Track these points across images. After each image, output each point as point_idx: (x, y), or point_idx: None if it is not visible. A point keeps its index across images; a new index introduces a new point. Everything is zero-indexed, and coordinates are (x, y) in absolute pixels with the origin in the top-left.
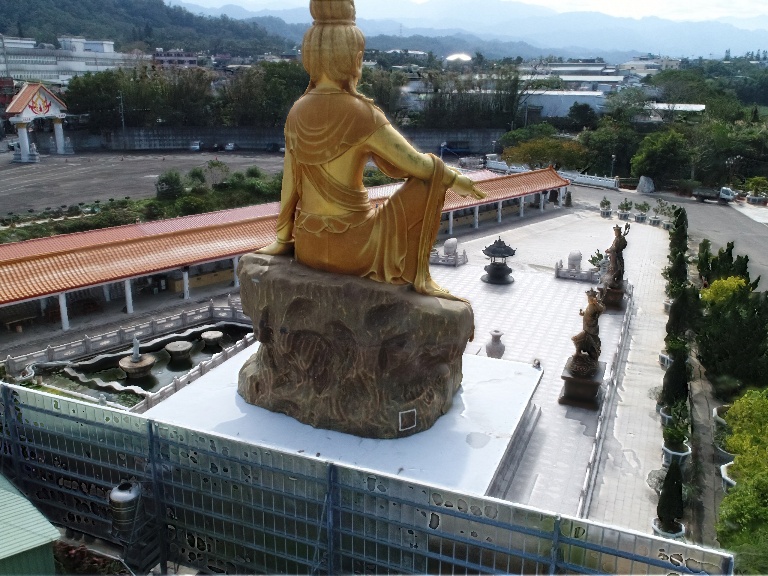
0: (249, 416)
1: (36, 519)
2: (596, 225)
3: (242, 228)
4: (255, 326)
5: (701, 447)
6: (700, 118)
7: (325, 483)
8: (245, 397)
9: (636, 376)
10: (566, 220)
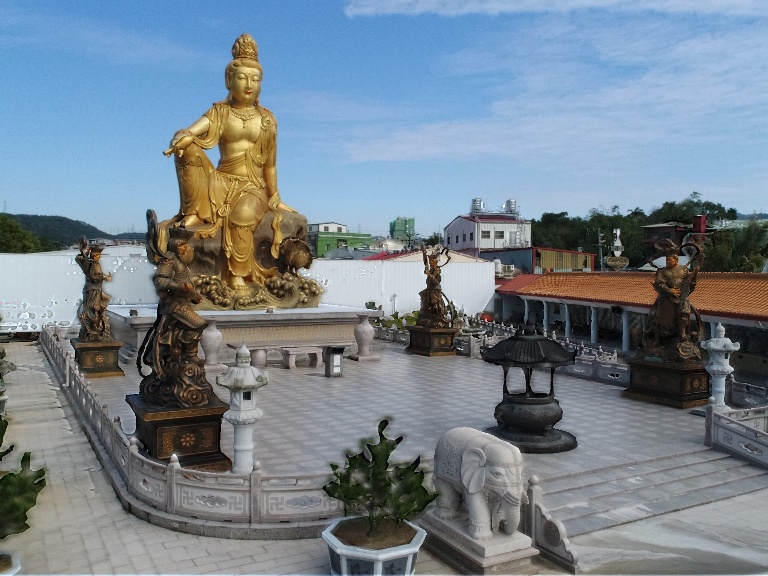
0: None
1: None
2: None
3: None
4: None
5: None
6: None
7: (141, 266)
8: None
9: (40, 399)
10: None
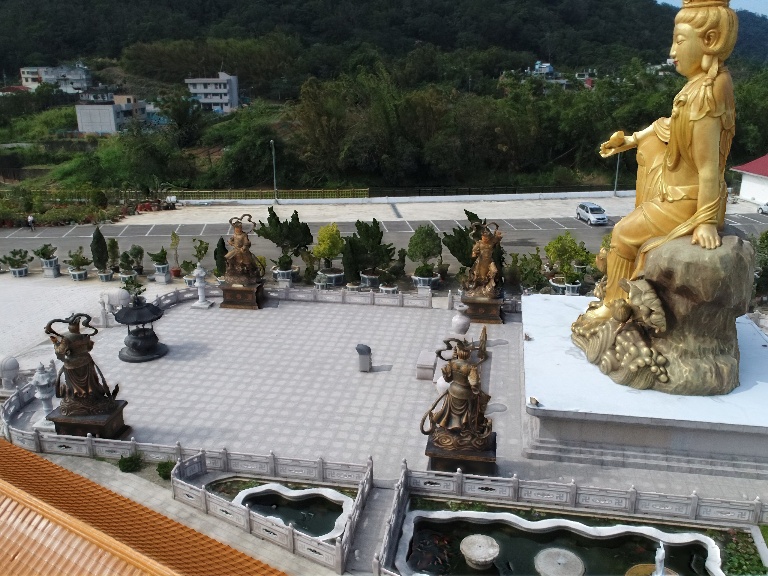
0: (759, 380)
1: None
2: None
3: (52, 504)
4: None
5: (519, 297)
6: None
7: None
8: None
9: None
10: None
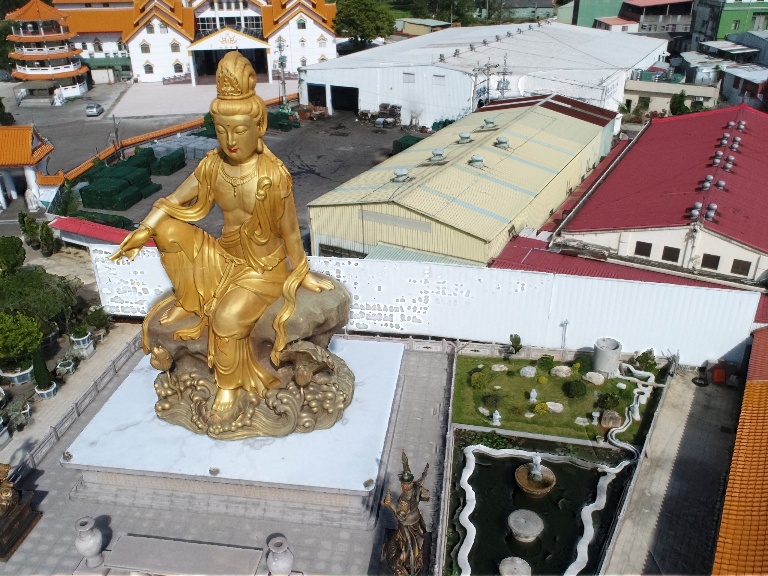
0: None
1: None
2: None
3: None
4: None
5: None
6: None
7: None
8: None
9: None
10: None
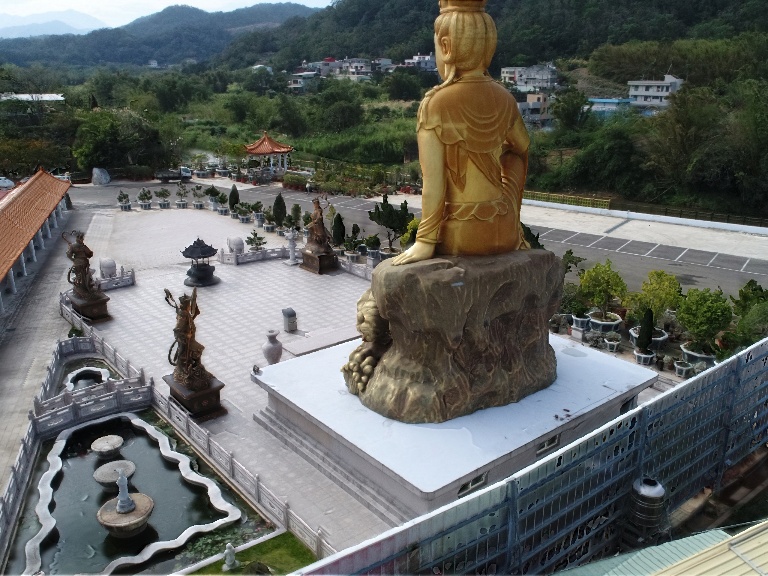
0: (470, 427)
1: (691, 542)
2: (141, 219)
3: None
4: (456, 333)
5: None
6: (64, 107)
7: None
8: (431, 420)
9: None
10: (104, 221)
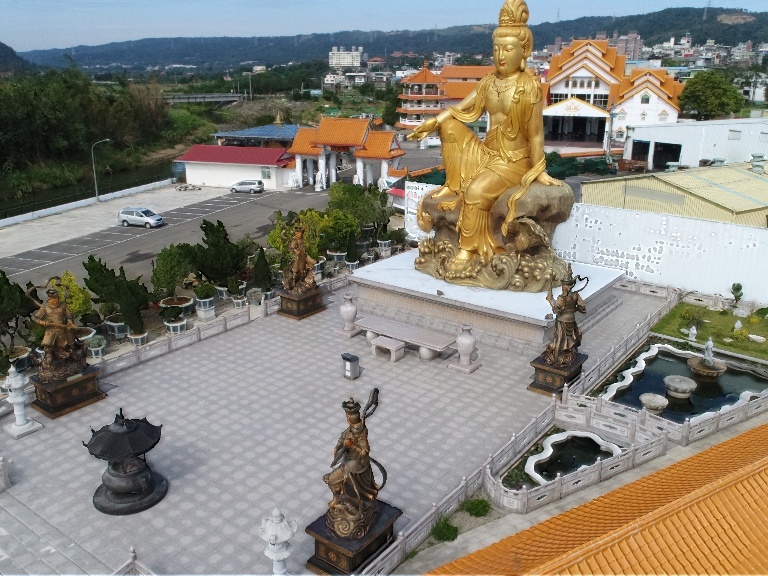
0: None
1: None
2: None
3: None
4: None
5: None
6: None
7: None
8: None
9: None
10: None
